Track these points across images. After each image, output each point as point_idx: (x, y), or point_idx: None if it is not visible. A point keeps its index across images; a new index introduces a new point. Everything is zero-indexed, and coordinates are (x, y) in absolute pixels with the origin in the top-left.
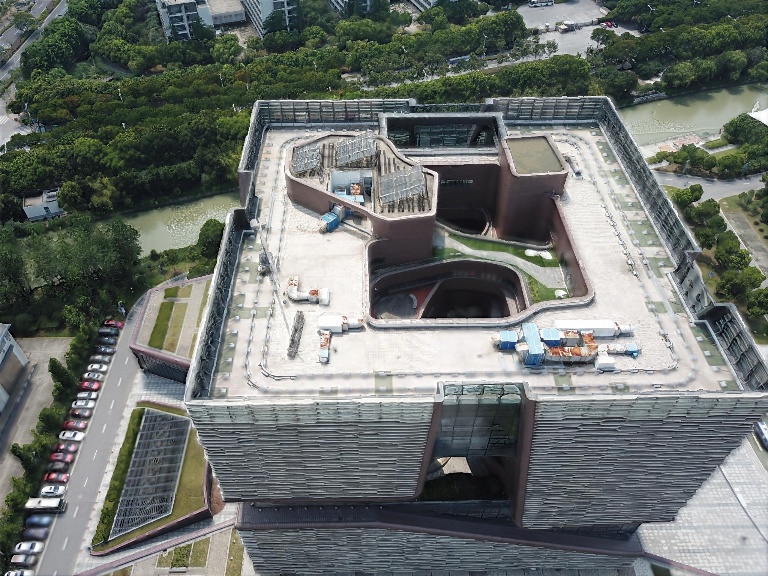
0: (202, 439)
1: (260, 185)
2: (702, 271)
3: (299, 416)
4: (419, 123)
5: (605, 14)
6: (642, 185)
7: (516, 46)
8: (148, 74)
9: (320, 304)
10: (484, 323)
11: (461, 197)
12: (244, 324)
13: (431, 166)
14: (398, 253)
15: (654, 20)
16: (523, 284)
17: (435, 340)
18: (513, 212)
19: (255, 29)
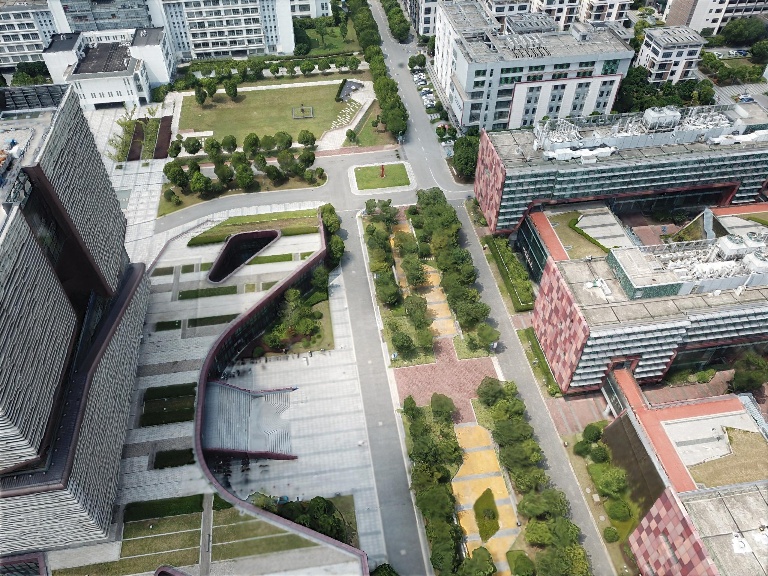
0: None
1: None
2: None
3: None
4: None
5: None
6: None
7: None
8: None
9: None
10: None
11: None
12: None
13: None
14: None
15: None
16: None
17: None
18: None
19: None
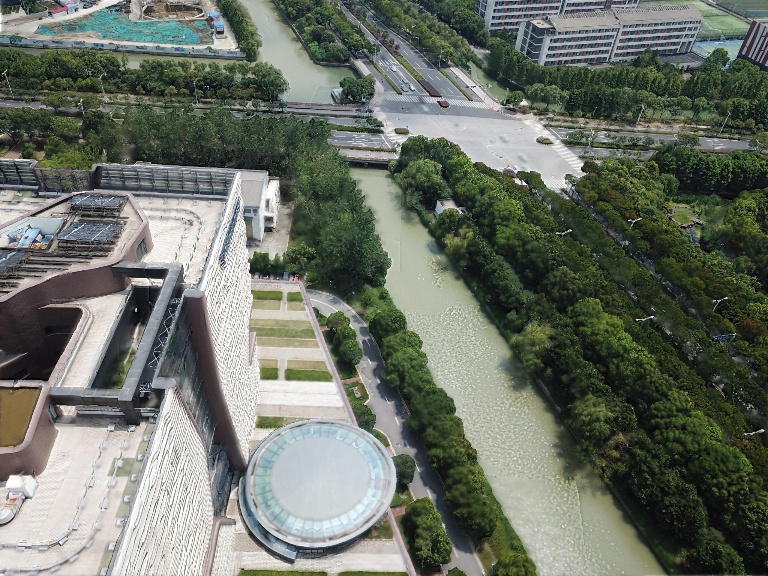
0: None
1: None
2: None
3: None
4: None
5: None
6: None
7: None
8: (730, 250)
9: None
10: None
11: None
12: None
13: None
14: None
15: None
16: None
17: None
18: None
19: None
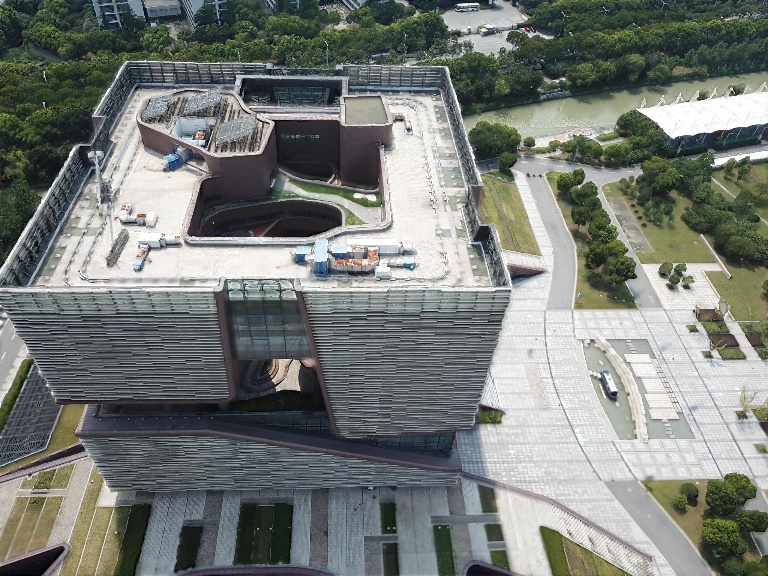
0: (17, 330)
1: (119, 133)
2: (577, 246)
3: (101, 307)
4: (274, 84)
5: (526, 20)
6: (458, 138)
7: (435, 45)
8: None
9: (147, 226)
10: (287, 241)
11: (311, 151)
12: (73, 240)
13: (279, 121)
14: (233, 190)
15: (566, 26)
16: (344, 219)
17: (242, 254)
18: (348, 161)
19: (190, 23)
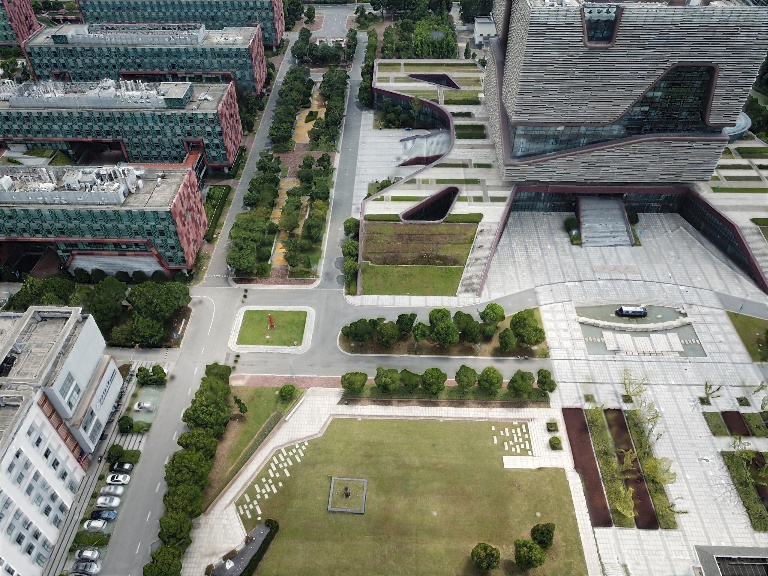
0: None
1: None
2: None
3: None
4: None
5: None
6: None
7: None
8: None
9: None
10: None
11: None
12: None
13: None
14: None
15: None
16: None
17: None
18: None
19: None
